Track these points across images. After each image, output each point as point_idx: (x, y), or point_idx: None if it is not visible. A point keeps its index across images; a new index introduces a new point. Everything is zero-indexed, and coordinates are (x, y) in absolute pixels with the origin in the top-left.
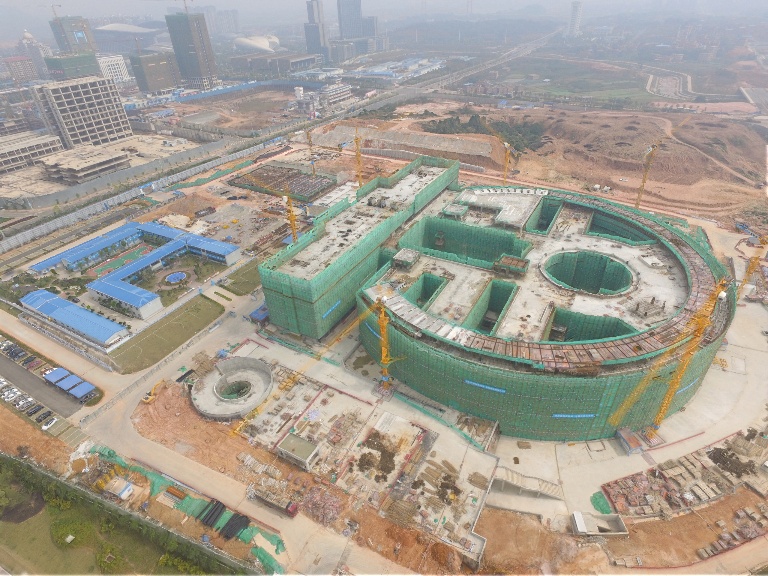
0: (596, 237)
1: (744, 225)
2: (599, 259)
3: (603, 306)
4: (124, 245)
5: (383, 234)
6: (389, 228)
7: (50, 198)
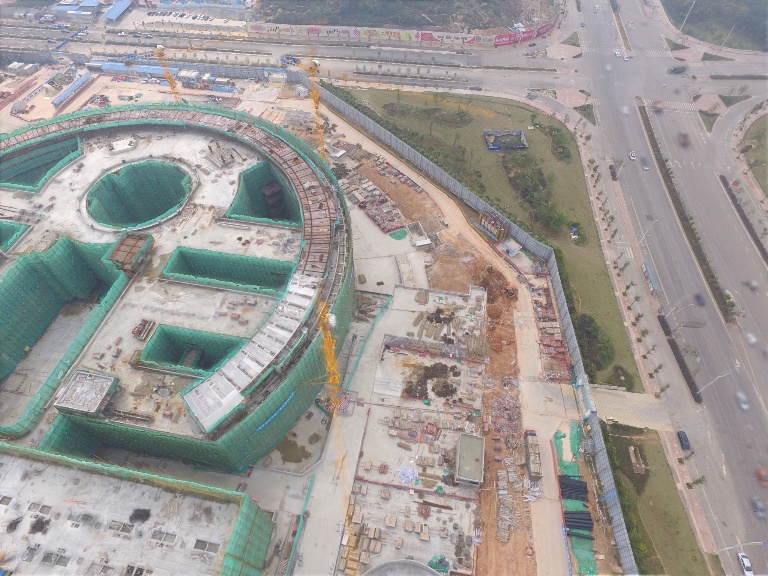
0: (49, 182)
1: (128, 55)
2: (103, 186)
3: (214, 184)
4: None
5: None
6: None
7: None
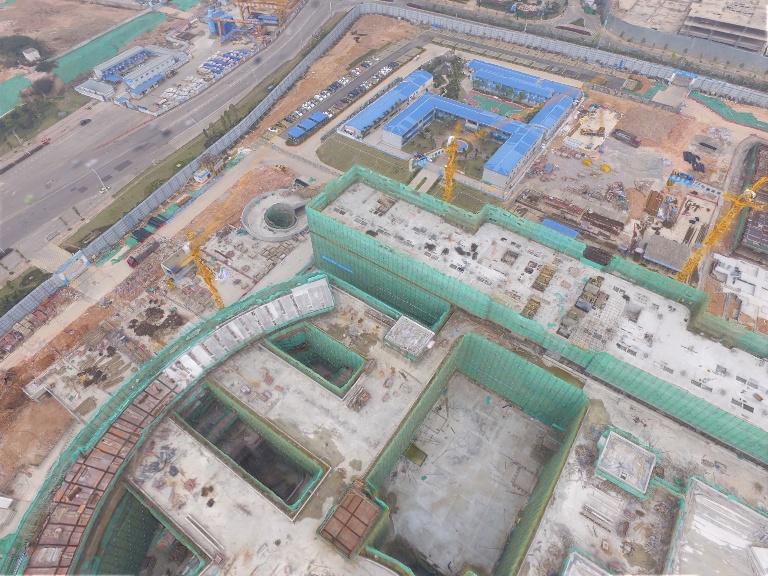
0: None
1: None
2: None
3: None
4: (521, 97)
5: (465, 299)
6: (486, 309)
7: (624, 27)
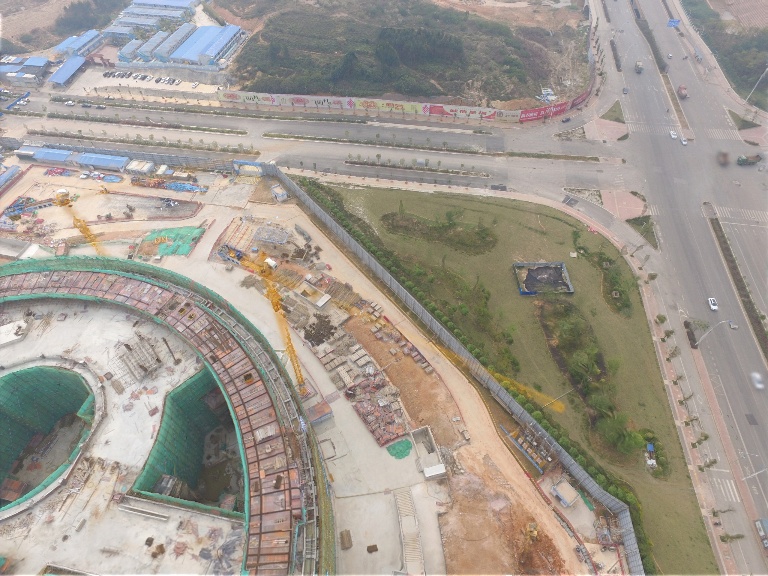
0: None
1: (13, 207)
2: None
3: (127, 415)
4: None
5: None
6: None
7: None
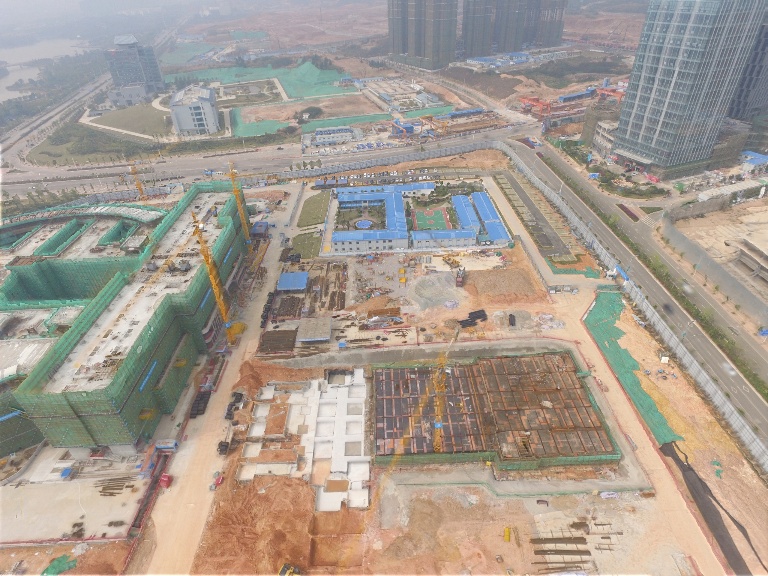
0: None
1: None
2: None
3: None
4: (455, 222)
5: None
6: None
7: None
